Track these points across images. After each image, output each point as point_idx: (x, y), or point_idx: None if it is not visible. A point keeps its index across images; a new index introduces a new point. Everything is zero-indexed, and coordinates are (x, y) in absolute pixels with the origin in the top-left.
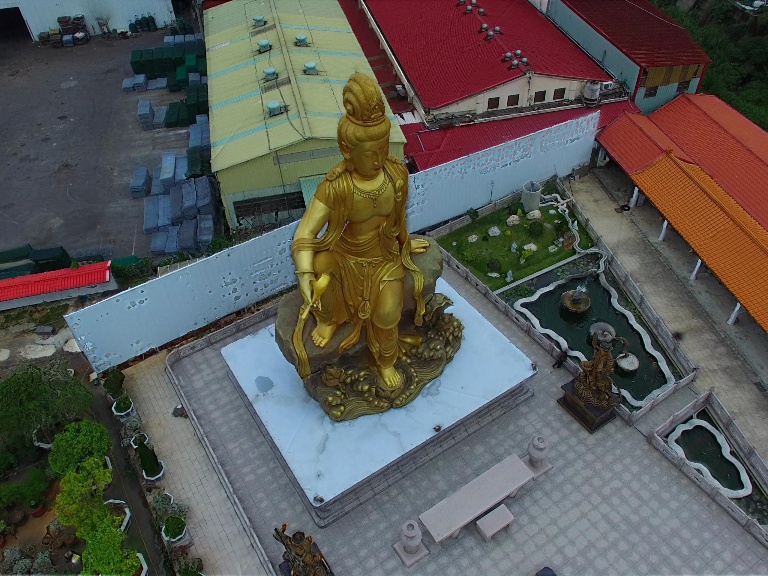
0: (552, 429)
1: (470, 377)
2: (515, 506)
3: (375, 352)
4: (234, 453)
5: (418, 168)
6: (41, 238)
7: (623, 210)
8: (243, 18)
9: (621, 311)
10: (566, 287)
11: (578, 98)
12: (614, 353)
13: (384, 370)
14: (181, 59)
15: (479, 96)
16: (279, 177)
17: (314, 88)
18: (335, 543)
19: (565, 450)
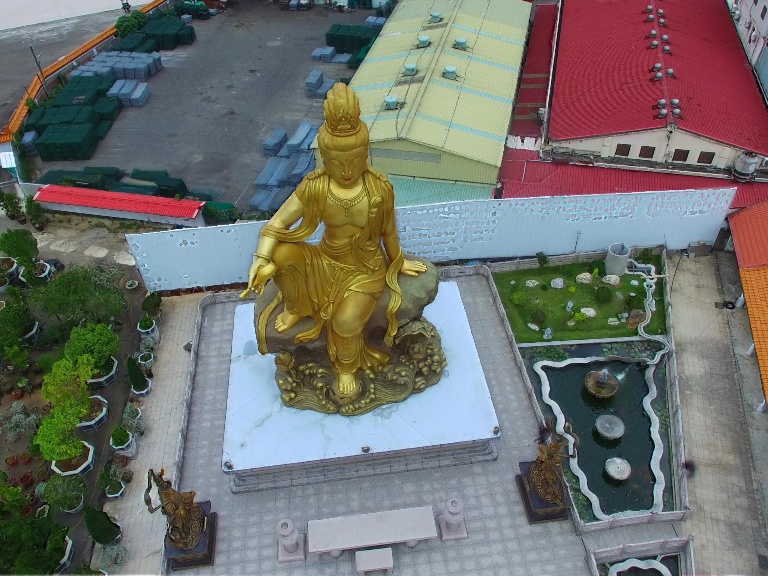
0: (492, 501)
1: (428, 415)
2: (408, 556)
3: (331, 354)
4: (207, 398)
5: (502, 195)
6: (180, 168)
7: (725, 307)
8: (426, 11)
9: (648, 413)
10: (603, 366)
11: (727, 168)
12: (612, 454)
13: (341, 375)
14: (368, 40)
15: (607, 138)
16: None
17: (442, 92)
18: (236, 511)
19: (492, 527)
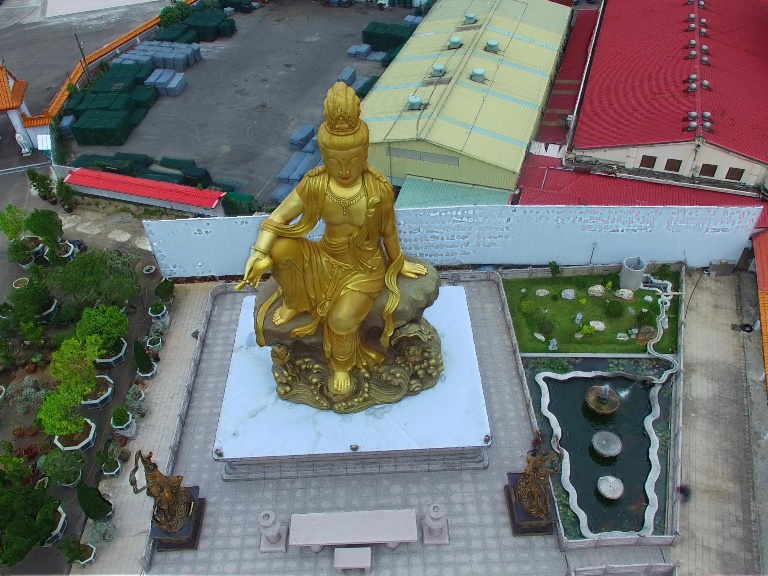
0: (478, 509)
1: (421, 418)
2: (387, 557)
3: (327, 351)
4: (209, 386)
5: (518, 202)
6: (207, 158)
7: (742, 329)
8: (462, 13)
9: (649, 433)
10: (606, 381)
11: (757, 185)
12: (607, 471)
13: (336, 372)
14: (404, 39)
15: (632, 149)
16: (388, 168)
17: (467, 94)
18: (224, 498)
19: (475, 535)
